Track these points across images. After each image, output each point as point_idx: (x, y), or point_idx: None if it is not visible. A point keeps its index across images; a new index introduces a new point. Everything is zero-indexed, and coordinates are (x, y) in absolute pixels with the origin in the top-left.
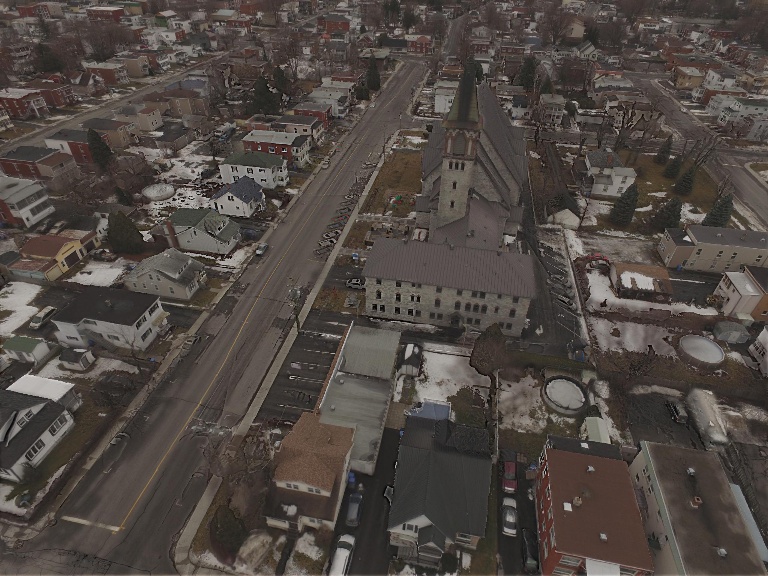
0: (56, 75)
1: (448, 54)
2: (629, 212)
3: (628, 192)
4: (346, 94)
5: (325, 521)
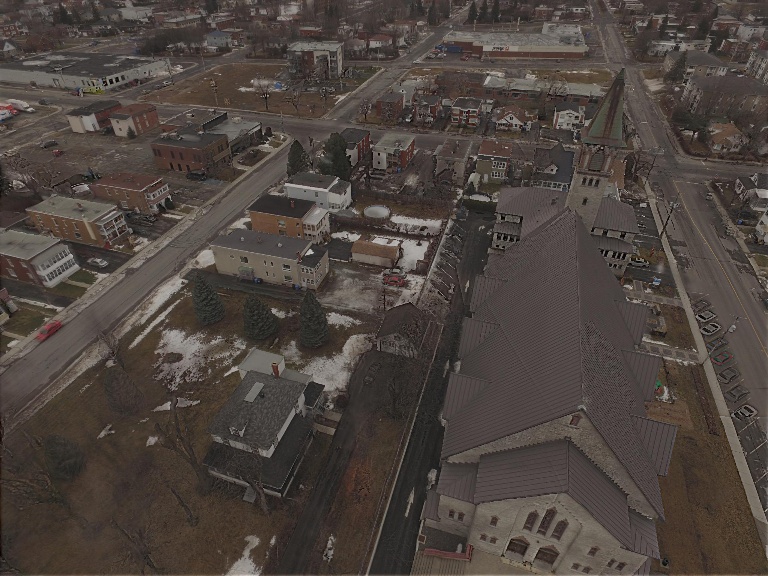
0: None
1: None
2: None
3: None
4: None
5: None
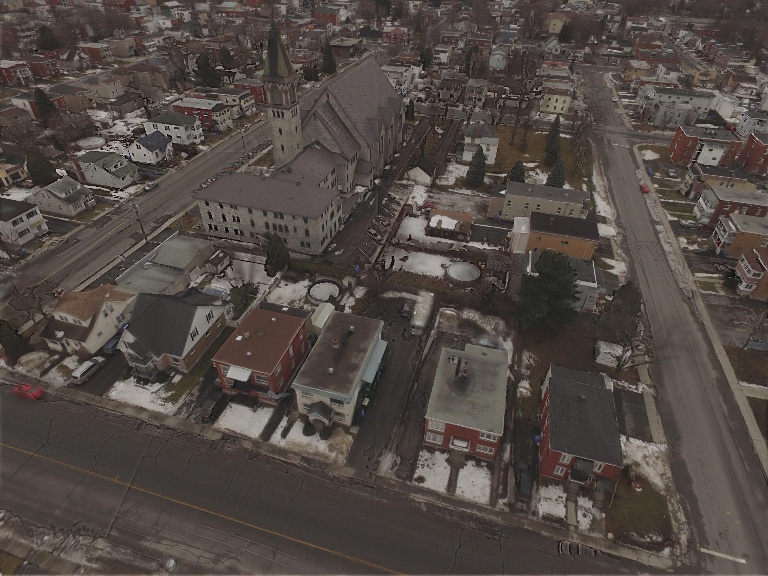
0: (52, 52)
1: (412, 44)
2: (478, 173)
3: (475, 155)
4: None
5: (83, 344)
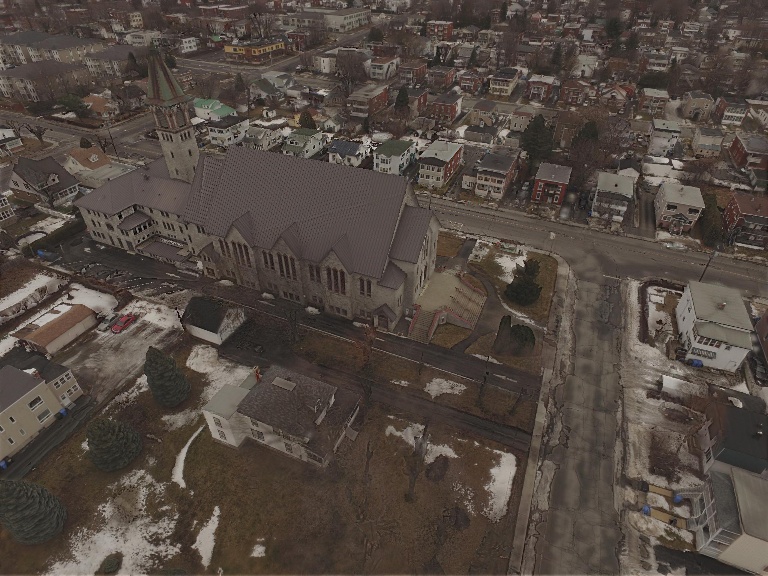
0: (630, 88)
1: None
2: None
3: None
4: None
5: None
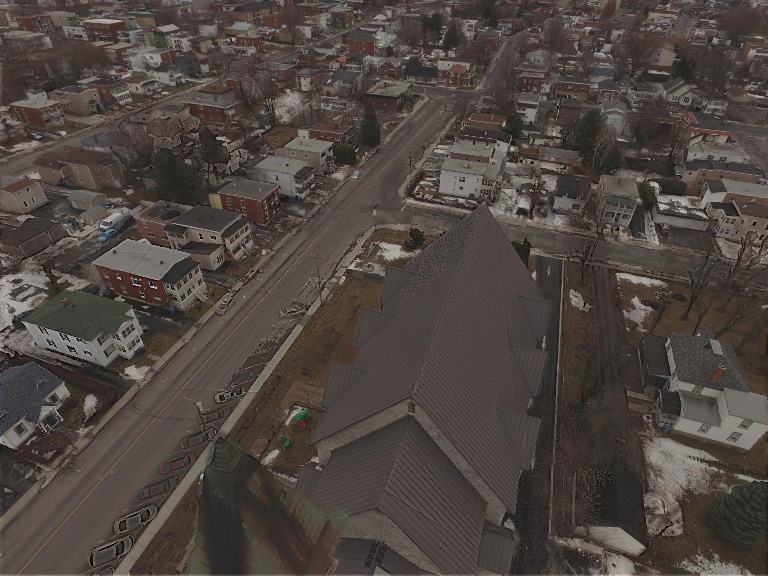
0: None
1: (484, 93)
2: (759, 533)
3: (762, 497)
4: (317, 159)
5: None
